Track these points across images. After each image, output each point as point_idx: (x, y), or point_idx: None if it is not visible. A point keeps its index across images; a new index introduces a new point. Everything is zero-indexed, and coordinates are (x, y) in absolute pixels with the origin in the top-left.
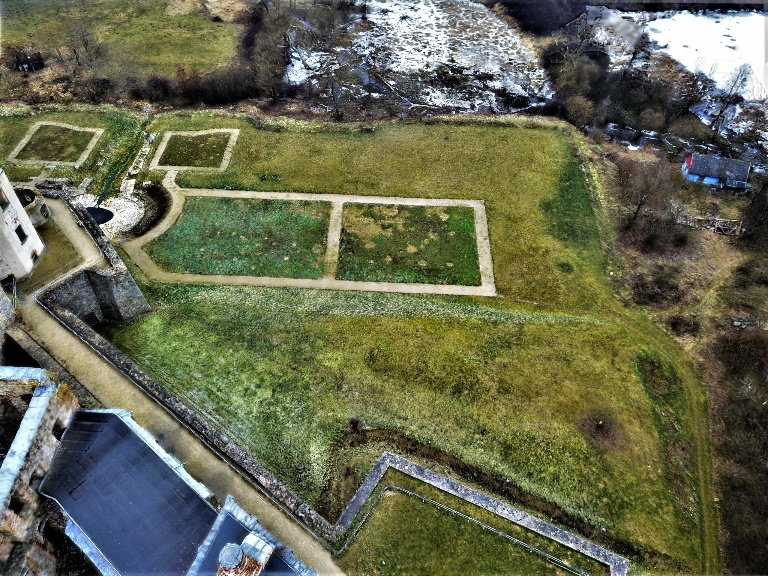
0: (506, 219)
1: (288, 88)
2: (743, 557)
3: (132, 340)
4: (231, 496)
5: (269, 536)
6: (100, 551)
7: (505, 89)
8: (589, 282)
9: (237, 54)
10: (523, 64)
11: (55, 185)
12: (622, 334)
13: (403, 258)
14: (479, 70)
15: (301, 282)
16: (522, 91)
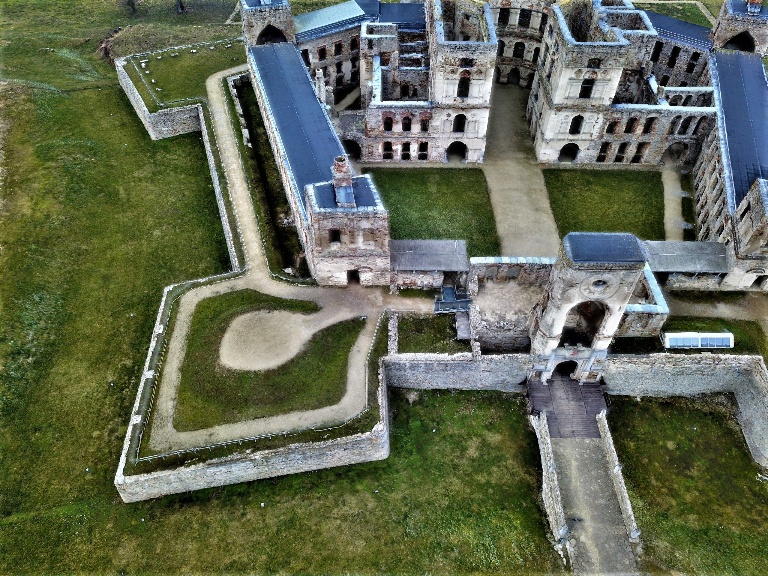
0: (718, 8)
1: None
2: None
3: None
4: None
5: None
6: (665, 30)
7: None
8: None
9: None
10: None
11: None
12: None
13: None
14: None
15: None
16: None
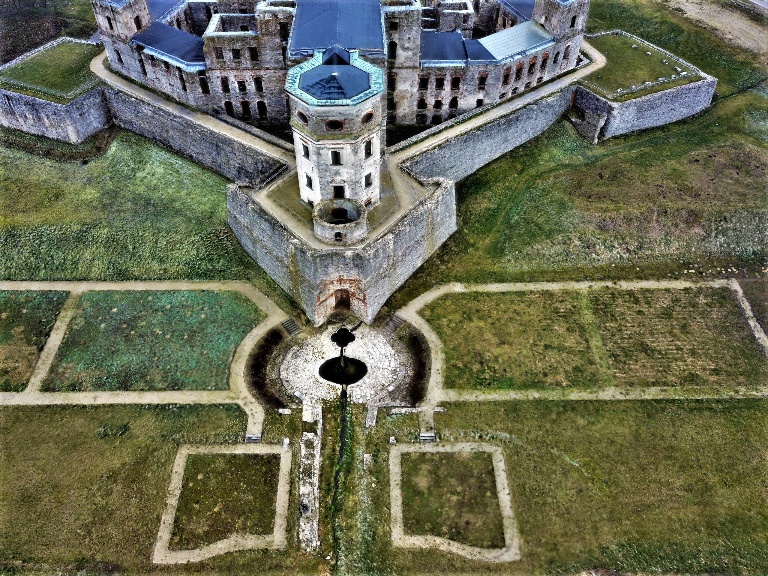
0: None
1: None
2: None
3: None
4: (117, 8)
5: (104, 2)
6: (183, 31)
7: None
8: None
9: None
10: None
11: (319, 252)
12: None
13: None
14: None
15: (105, 287)
16: None
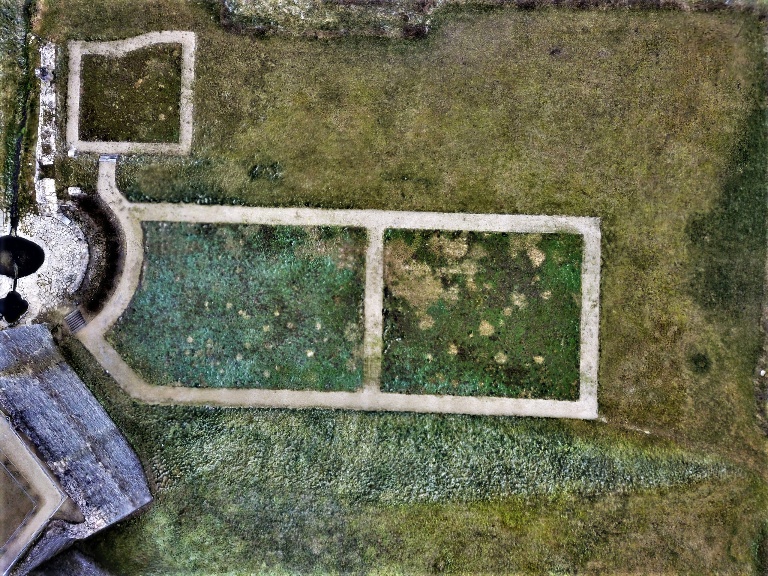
0: (630, 262)
1: None
2: None
3: (140, 550)
4: None
5: None
6: None
7: None
8: (728, 392)
9: None
10: None
11: None
12: (751, 492)
13: (473, 349)
14: None
15: (335, 398)
16: None
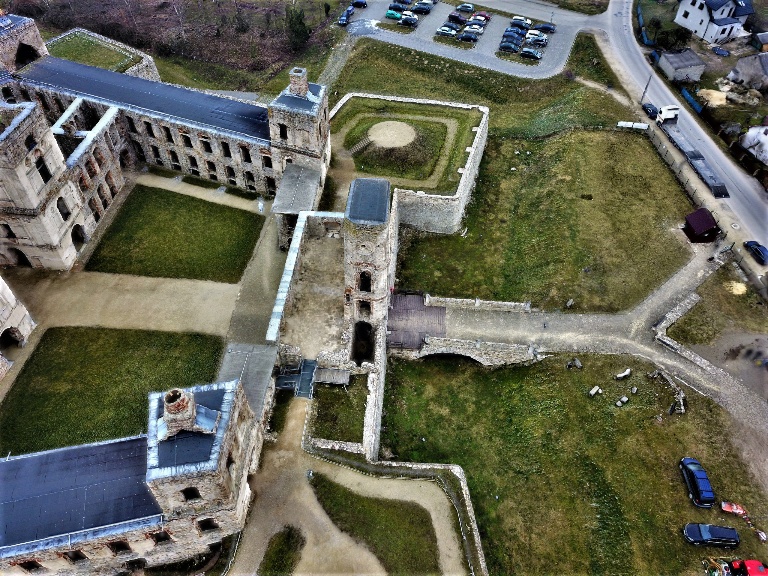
0: None
1: None
2: (105, 33)
3: None
4: None
5: None
6: None
7: None
8: None
9: None
10: None
11: None
12: None
13: None
14: None
15: None
16: None
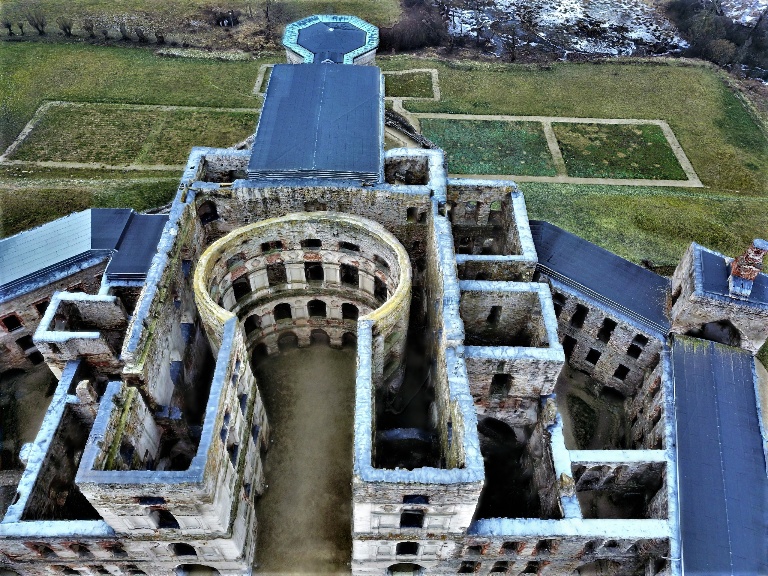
0: (689, 133)
1: (455, 39)
2: None
3: None
4: None
5: None
6: (591, 290)
7: (642, 39)
8: None
9: (403, 11)
10: (650, 19)
11: None
12: None
13: (617, 161)
14: (613, 24)
15: (542, 179)
16: (656, 40)
